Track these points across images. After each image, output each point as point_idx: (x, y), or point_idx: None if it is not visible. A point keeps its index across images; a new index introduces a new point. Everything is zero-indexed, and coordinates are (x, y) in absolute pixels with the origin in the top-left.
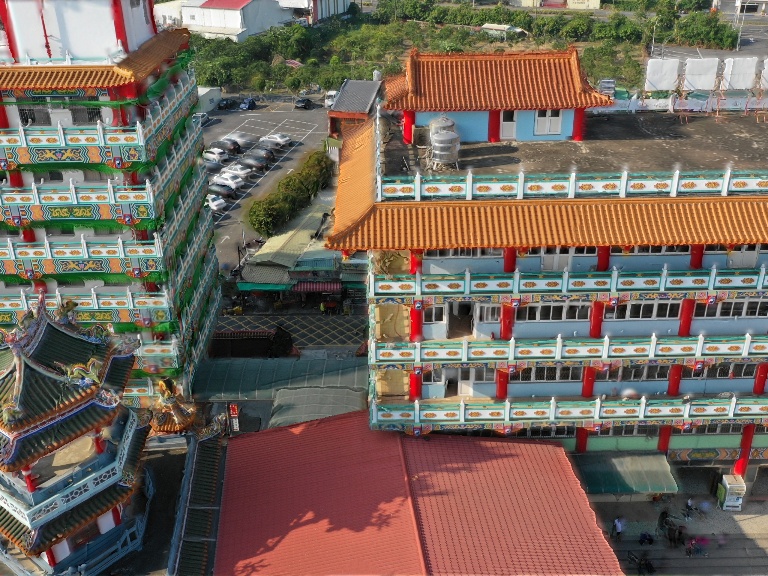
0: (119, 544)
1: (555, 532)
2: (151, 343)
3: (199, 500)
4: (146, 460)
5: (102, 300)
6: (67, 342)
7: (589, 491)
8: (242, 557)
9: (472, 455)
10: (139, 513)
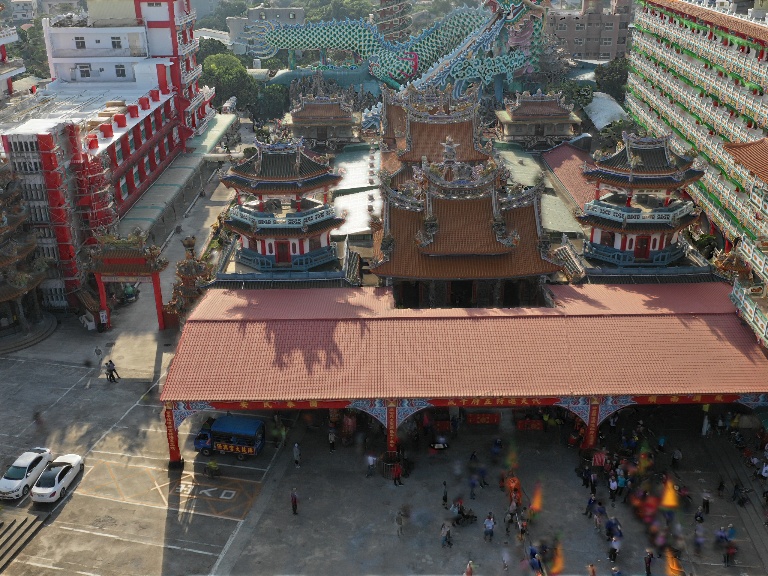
0: (612, 254)
1: (676, 369)
2: (767, 227)
3: (666, 280)
4: (690, 264)
5: (764, 187)
6: (661, 158)
7: (763, 422)
8: (622, 287)
9: (739, 343)
10: (641, 261)
